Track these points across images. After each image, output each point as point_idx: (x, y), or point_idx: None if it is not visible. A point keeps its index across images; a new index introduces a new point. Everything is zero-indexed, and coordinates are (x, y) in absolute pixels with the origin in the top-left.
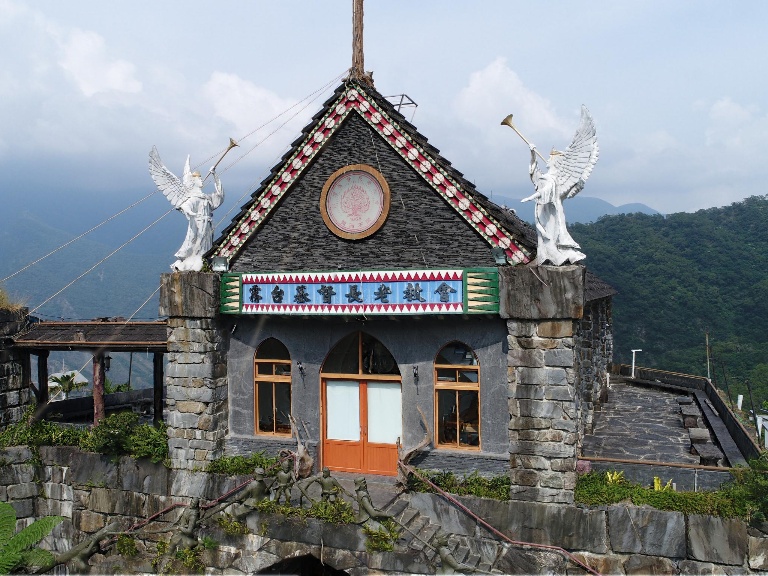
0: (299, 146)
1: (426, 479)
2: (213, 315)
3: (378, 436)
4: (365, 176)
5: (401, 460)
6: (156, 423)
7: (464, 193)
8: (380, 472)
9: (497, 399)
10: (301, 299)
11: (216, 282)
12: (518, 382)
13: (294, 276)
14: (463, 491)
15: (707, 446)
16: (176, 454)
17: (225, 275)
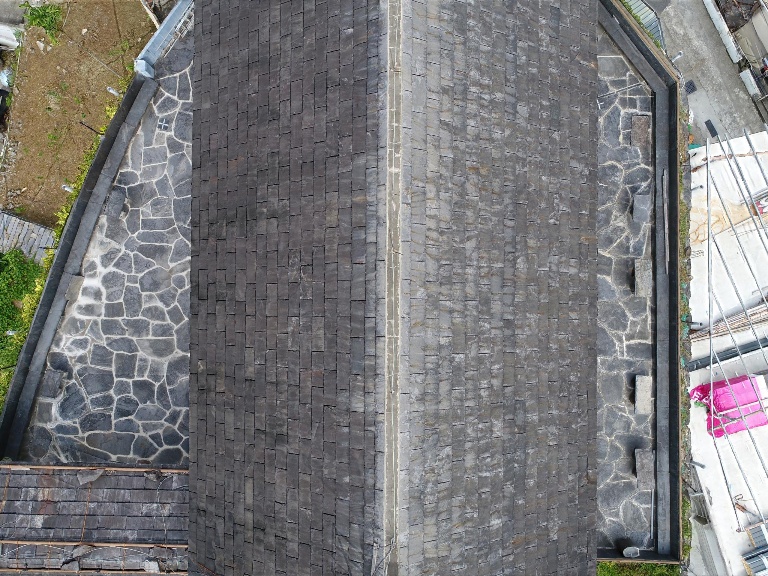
0: None
1: None
2: None
3: None
4: None
5: None
6: None
7: None
8: None
9: None
10: None
11: None
12: None
13: None
14: None
15: (646, 460)
16: None
17: None
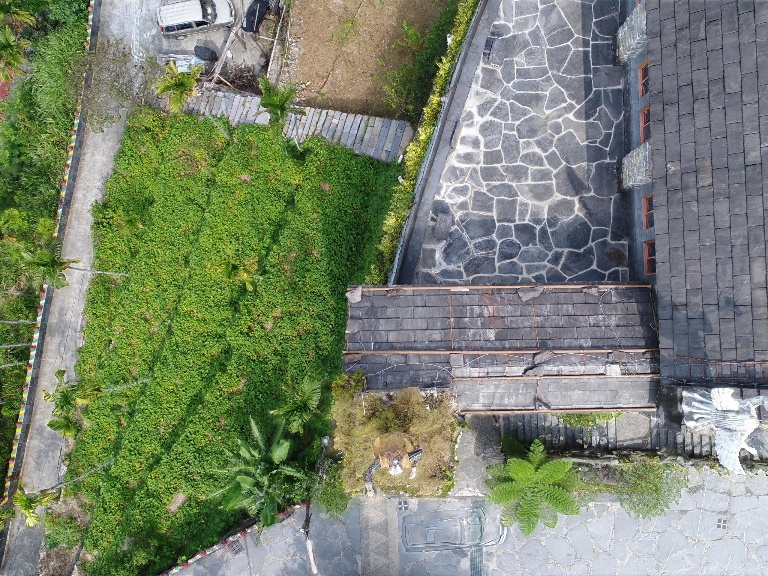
0: None
1: None
2: None
3: None
4: None
5: None
6: None
7: None
8: None
9: None
10: None
11: None
12: None
13: None
14: None
15: None
16: None
17: None
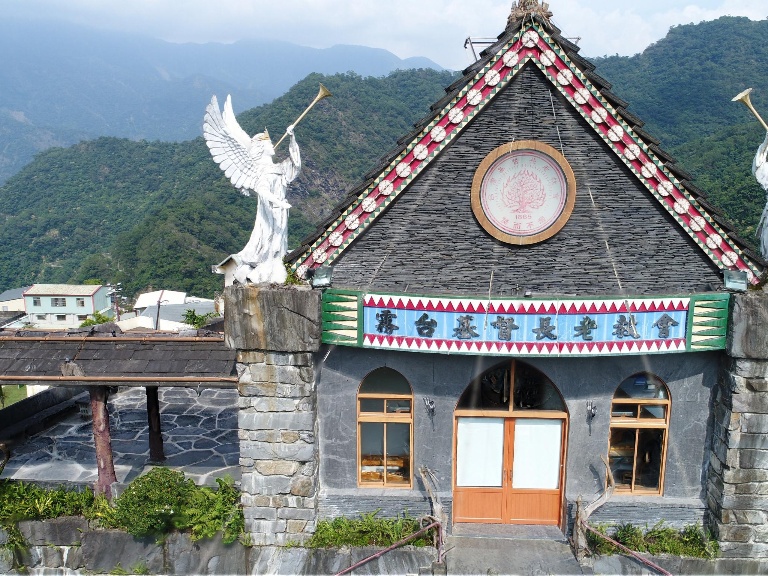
0: (443, 108)
1: (605, 536)
2: (316, 349)
3: (525, 480)
4: (540, 158)
5: (584, 521)
6: (154, 448)
7: (683, 192)
8: (527, 521)
9: (690, 439)
10: (465, 334)
11: (319, 303)
12: (743, 430)
13: (456, 303)
14: (656, 549)
15: None
16: (257, 527)
17: (330, 291)
